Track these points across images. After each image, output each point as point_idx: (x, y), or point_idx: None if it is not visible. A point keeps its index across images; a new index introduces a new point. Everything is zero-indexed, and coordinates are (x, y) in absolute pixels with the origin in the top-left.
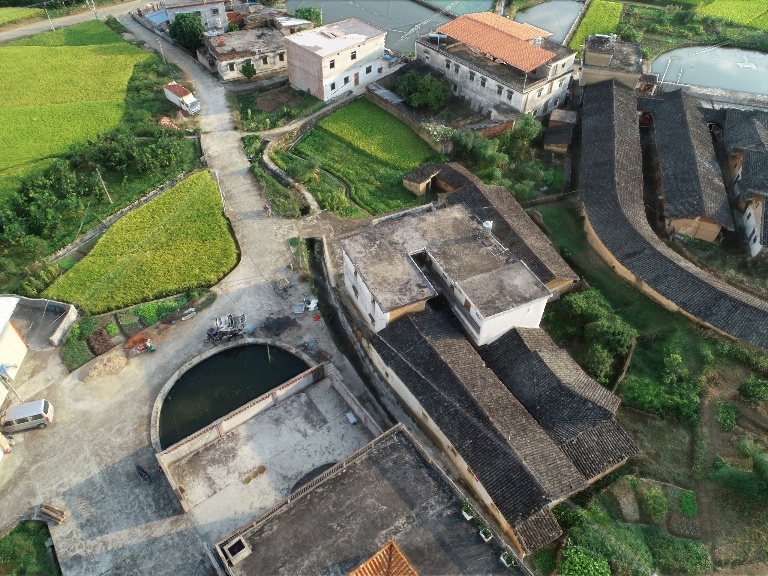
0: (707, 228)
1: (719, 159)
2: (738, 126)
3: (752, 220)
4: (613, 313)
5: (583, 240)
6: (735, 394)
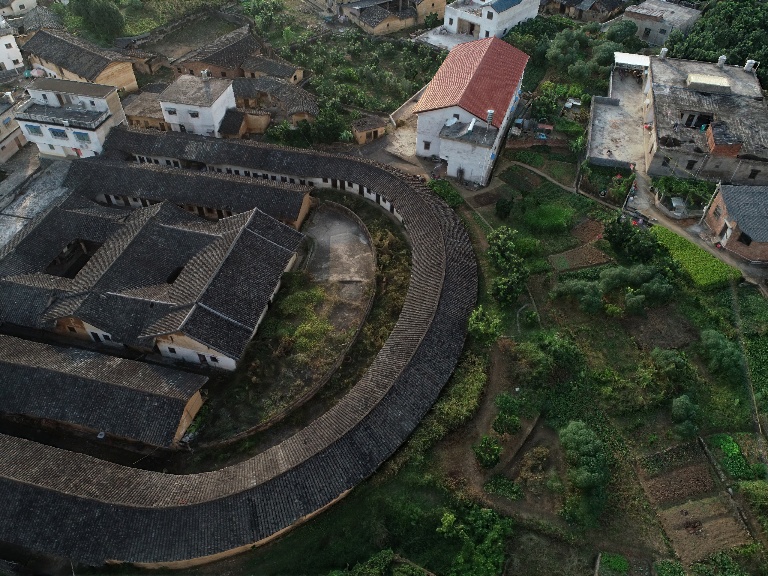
0: (192, 403)
1: (37, 339)
2: (2, 300)
3: (183, 351)
4: (350, 573)
5: (173, 575)
6: (479, 470)
